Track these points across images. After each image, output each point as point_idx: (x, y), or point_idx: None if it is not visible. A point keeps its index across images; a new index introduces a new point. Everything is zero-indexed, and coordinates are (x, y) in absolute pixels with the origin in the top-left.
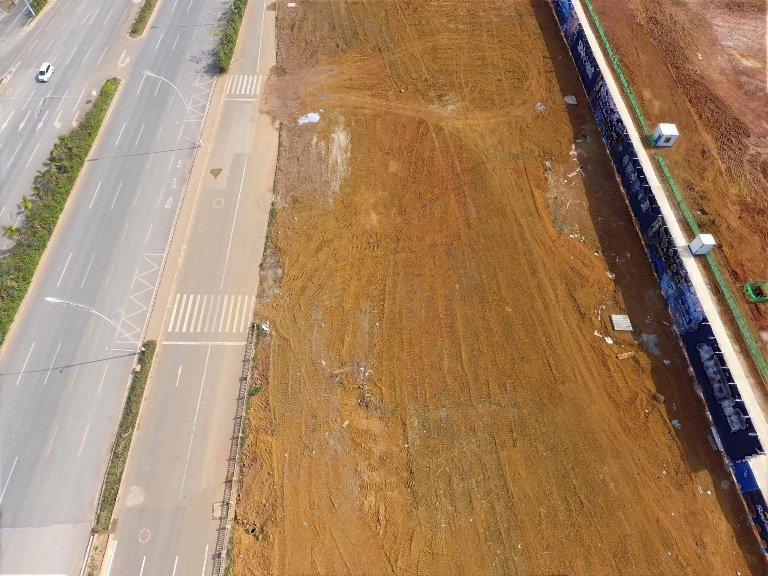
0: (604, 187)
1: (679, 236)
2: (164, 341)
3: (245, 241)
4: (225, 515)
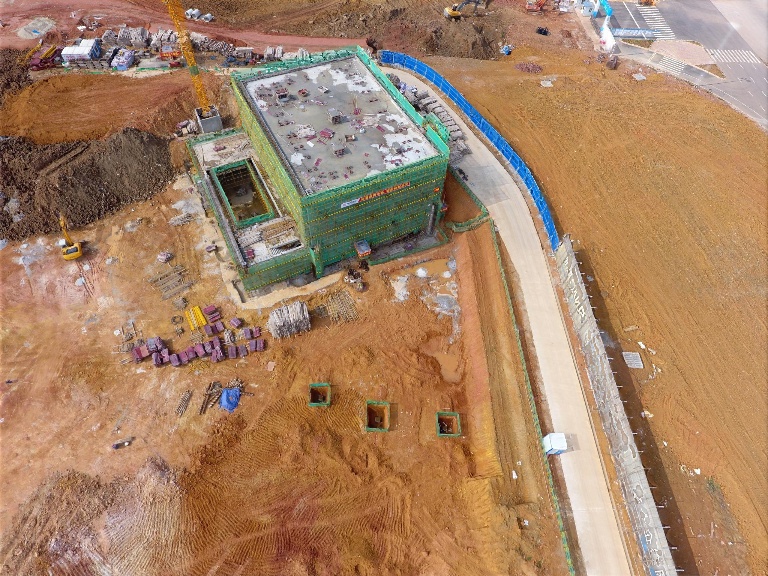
0: None
1: (570, 468)
2: None
3: None
4: None
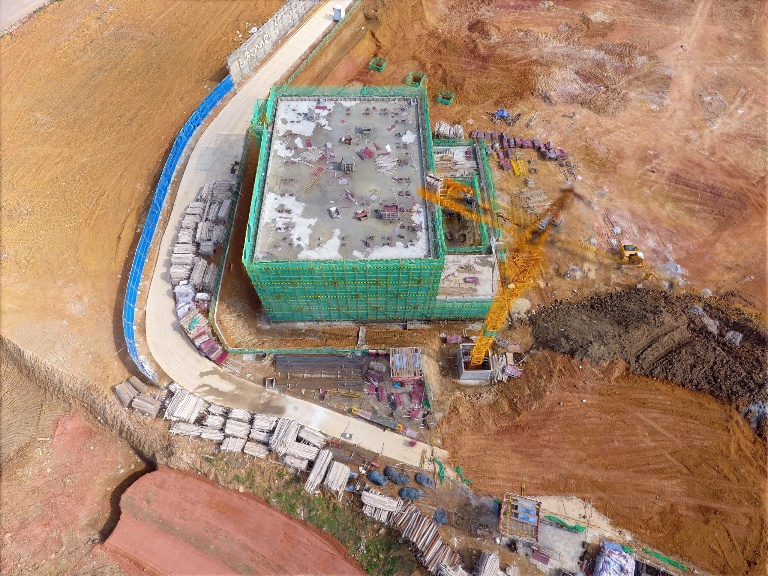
0: None
1: None
2: None
3: None
4: (8, 29)
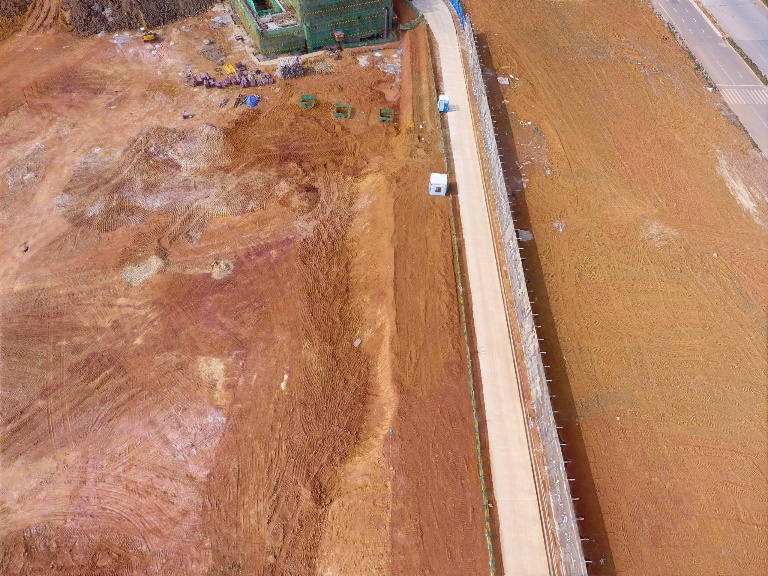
0: (500, 154)
1: (452, 117)
2: (761, 86)
3: (759, 130)
4: None
